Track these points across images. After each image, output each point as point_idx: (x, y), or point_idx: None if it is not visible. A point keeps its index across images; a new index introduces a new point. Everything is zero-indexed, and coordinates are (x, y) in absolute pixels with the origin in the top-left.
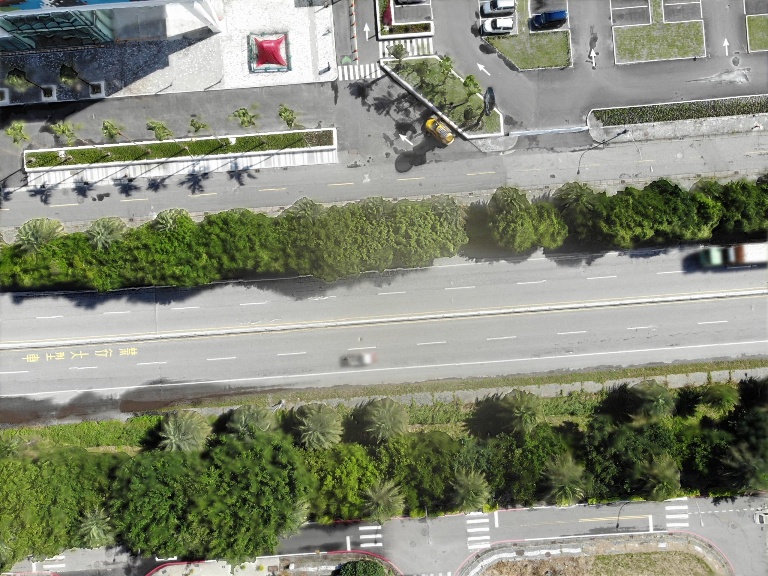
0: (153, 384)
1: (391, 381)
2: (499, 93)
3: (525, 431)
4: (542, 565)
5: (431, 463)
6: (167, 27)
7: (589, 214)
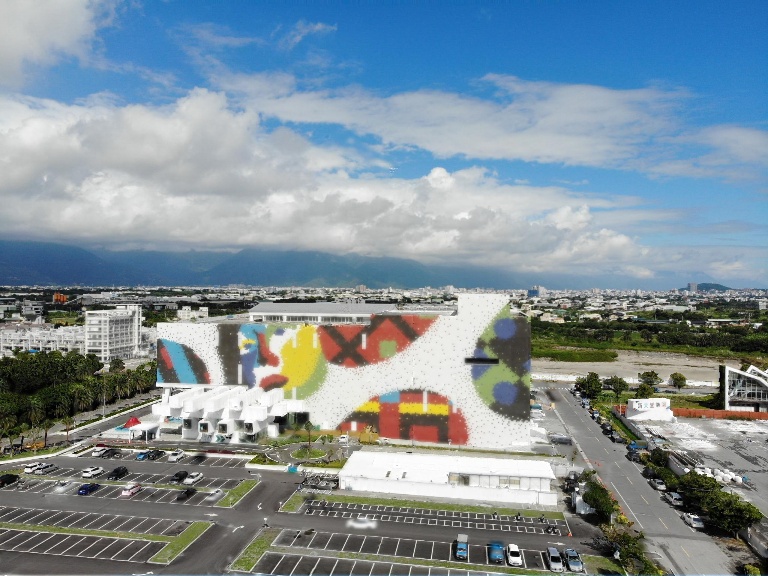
0: None
1: None
2: None
3: None
4: None
5: None
6: None
7: None
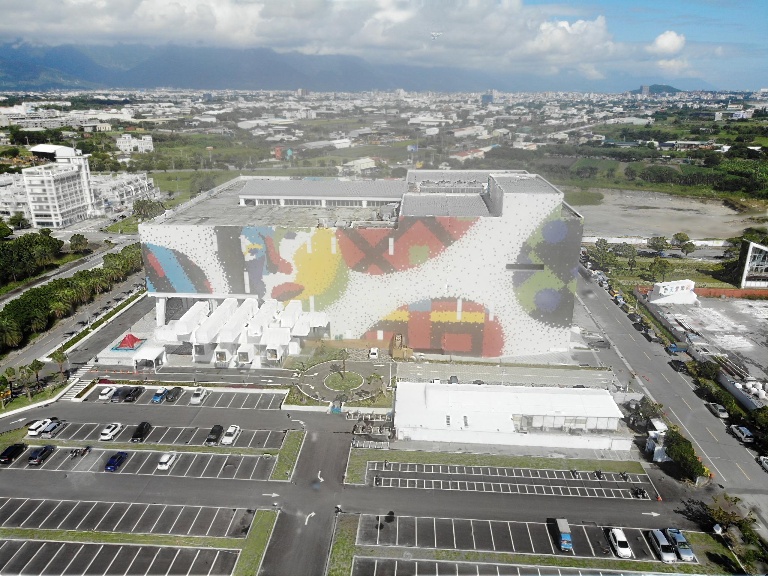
0: None
1: None
2: None
3: None
4: None
5: None
6: None
7: None
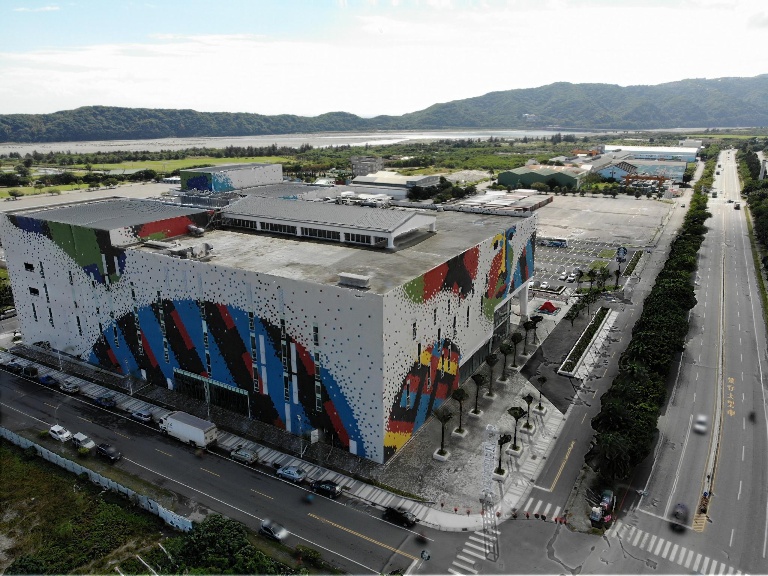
0: (761, 380)
1: (764, 326)
2: None
3: None
4: None
5: None
6: (513, 323)
7: (679, 265)
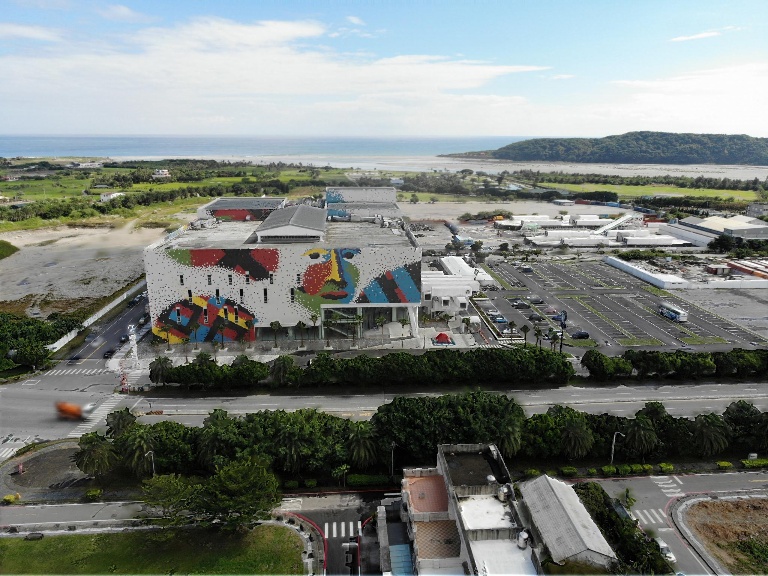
0: None
1: None
2: (567, 351)
3: (661, 416)
4: (739, 502)
5: (602, 418)
6: (391, 336)
7: (639, 355)
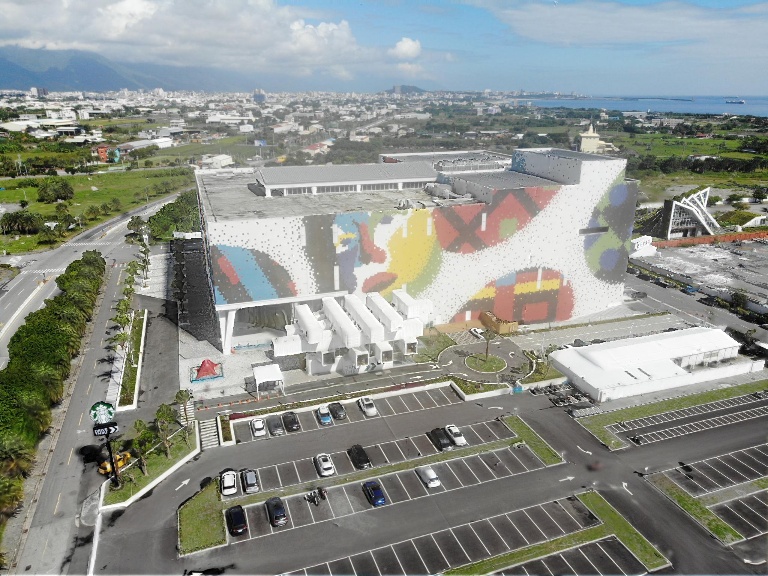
0: None
1: None
2: (154, 500)
3: None
4: None
5: None
6: None
7: None
